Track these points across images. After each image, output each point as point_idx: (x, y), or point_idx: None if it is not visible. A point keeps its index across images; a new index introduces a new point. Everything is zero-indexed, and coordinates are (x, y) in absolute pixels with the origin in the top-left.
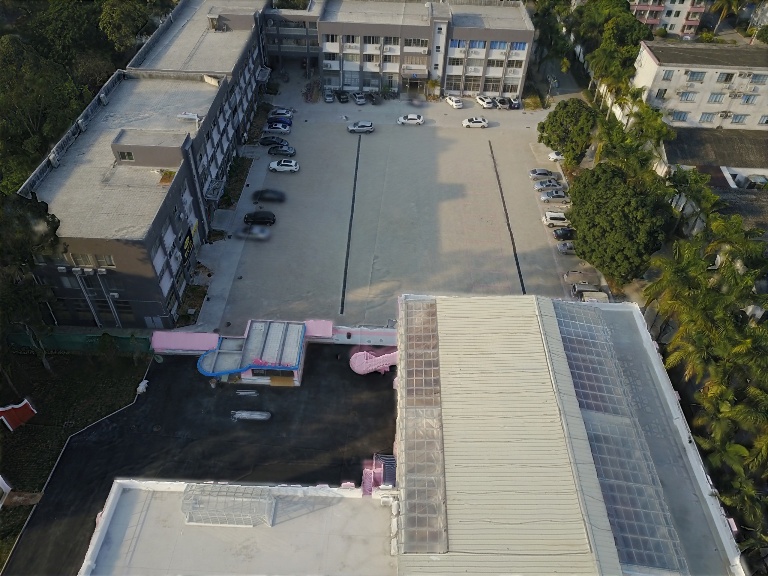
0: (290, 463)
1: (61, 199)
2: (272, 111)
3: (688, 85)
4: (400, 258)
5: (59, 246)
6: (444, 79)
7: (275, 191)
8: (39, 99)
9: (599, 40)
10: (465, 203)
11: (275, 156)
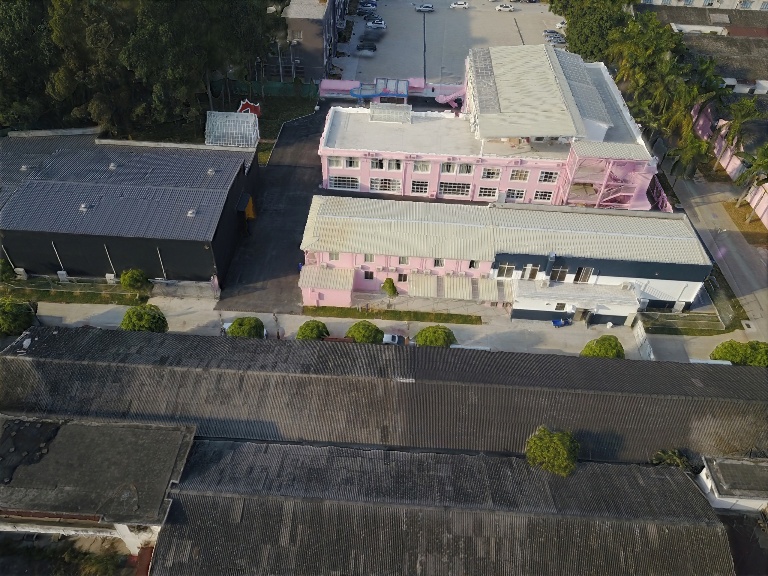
0: None
1: None
2: None
3: None
4: (458, 68)
5: None
6: None
7: (374, 35)
8: None
9: None
10: None
11: (369, 21)
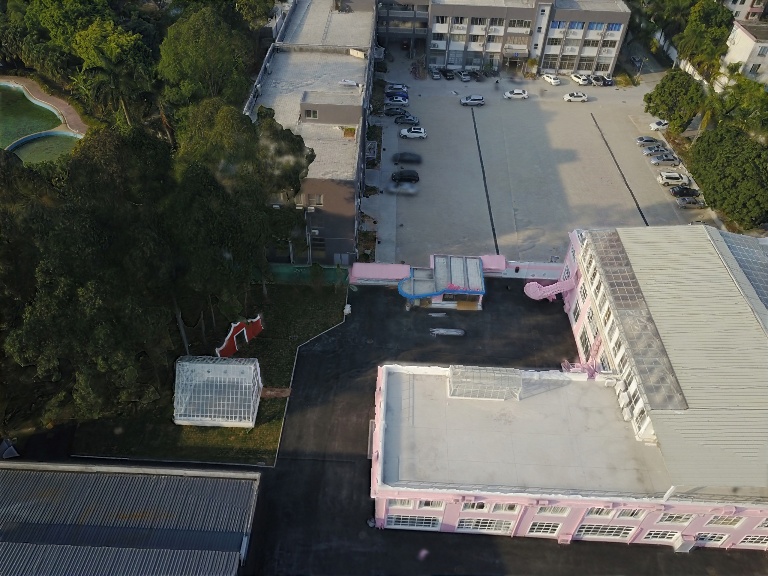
0: None
1: None
2: (388, 86)
3: None
4: (537, 210)
5: None
6: (542, 58)
7: (413, 154)
8: (220, 66)
9: (682, 23)
10: (583, 166)
11: (401, 125)
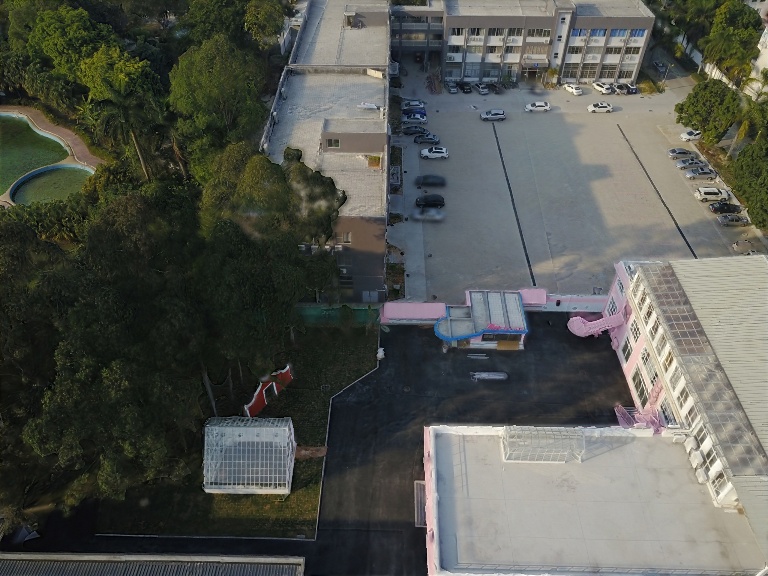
0: (540, 416)
1: None
2: (404, 103)
3: None
4: (572, 234)
5: None
6: (562, 67)
7: (436, 176)
8: (234, 94)
9: (706, 25)
10: (615, 182)
11: (421, 144)
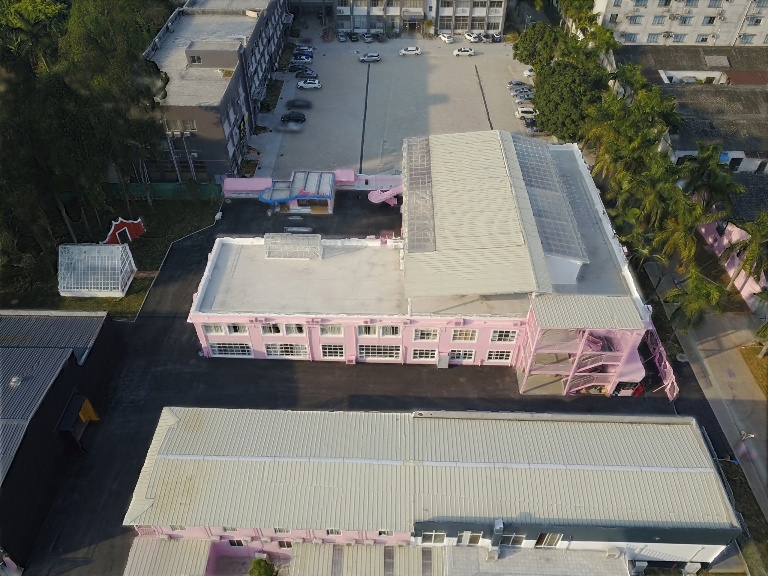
0: None
1: None
2: (296, 48)
3: (635, 10)
4: None
5: (157, 114)
6: (437, 20)
7: (304, 100)
8: None
9: None
10: (455, 106)
11: (301, 79)
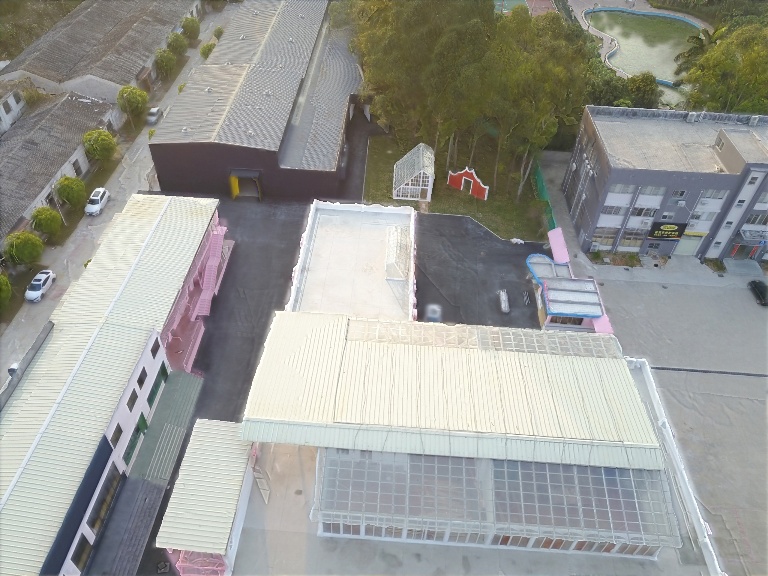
0: None
1: (649, 131)
2: None
3: None
4: None
5: None
6: None
7: None
8: None
9: None
10: None
11: None
